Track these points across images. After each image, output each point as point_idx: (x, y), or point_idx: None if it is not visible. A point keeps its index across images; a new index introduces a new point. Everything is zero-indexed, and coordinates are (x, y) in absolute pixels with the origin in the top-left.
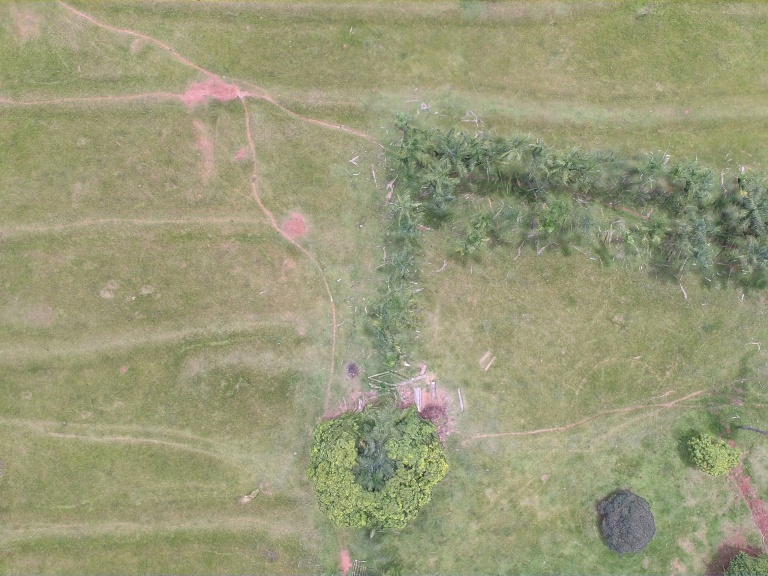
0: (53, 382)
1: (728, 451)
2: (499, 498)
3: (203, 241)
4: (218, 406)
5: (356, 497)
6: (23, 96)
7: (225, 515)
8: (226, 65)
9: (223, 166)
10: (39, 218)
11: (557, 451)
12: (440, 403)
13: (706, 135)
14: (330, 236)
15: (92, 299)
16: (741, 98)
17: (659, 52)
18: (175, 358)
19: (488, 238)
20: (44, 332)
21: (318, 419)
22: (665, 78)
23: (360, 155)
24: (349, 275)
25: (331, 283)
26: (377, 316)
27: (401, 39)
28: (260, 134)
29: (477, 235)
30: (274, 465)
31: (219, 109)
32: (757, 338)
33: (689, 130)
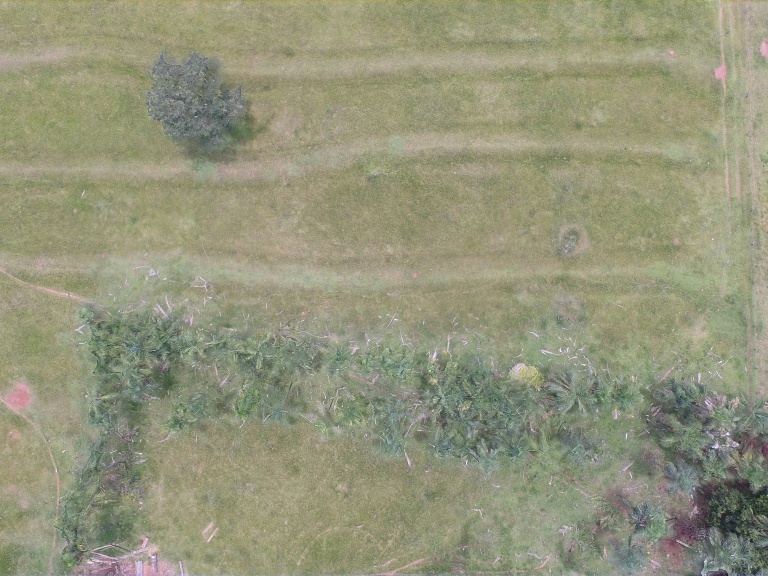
0: None
1: None
2: None
3: None
4: None
5: None
6: None
7: None
8: None
9: None
10: None
11: None
12: None
13: (435, 298)
14: (54, 407)
15: None
16: (471, 260)
17: (390, 214)
18: None
19: (195, 418)
20: None
21: None
22: (396, 240)
23: None
24: (73, 446)
25: (56, 454)
26: None
27: (133, 203)
28: None
29: (177, 420)
30: None
31: None
32: (480, 504)
33: (418, 293)
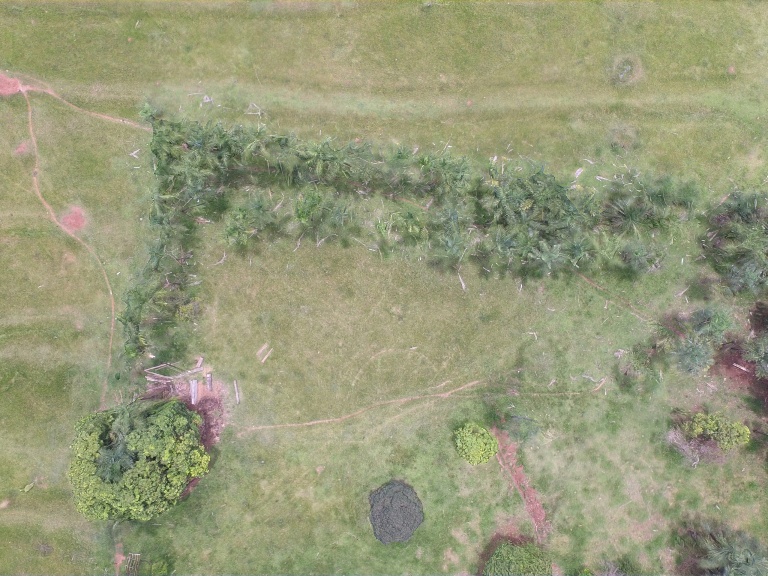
0: None
1: (485, 440)
2: (274, 490)
3: None
4: None
5: (94, 489)
6: None
7: None
8: (9, 59)
9: (4, 160)
10: None
11: (332, 442)
12: (216, 395)
13: (488, 126)
14: (109, 229)
15: None
16: (525, 89)
17: (444, 43)
18: None
19: (253, 230)
20: None
21: (94, 412)
22: (449, 69)
23: (141, 148)
24: (128, 268)
25: (110, 276)
26: None
27: (186, 32)
28: (41, 128)
29: (236, 227)
30: (50, 459)
31: (1, 103)
32: (534, 328)
33: (472, 121)
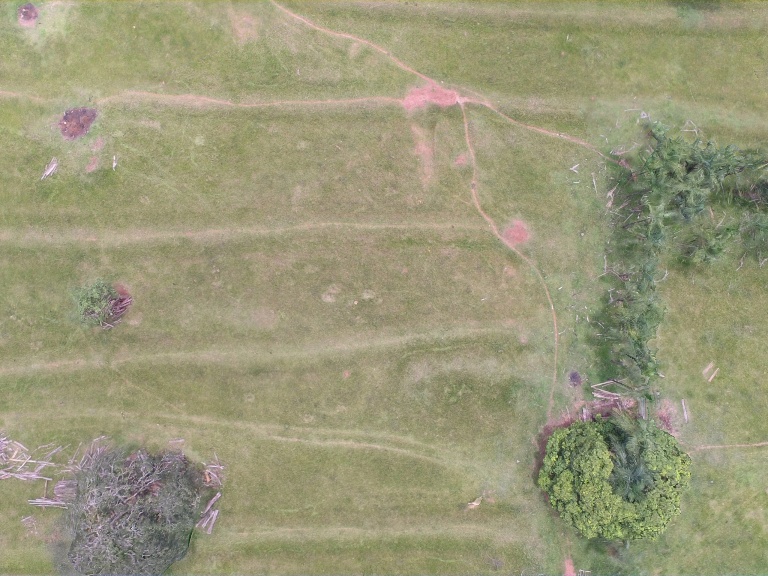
0: (276, 385)
1: None
2: (724, 510)
3: (423, 247)
4: (441, 412)
5: (617, 508)
6: (243, 98)
7: (449, 522)
8: (444, 70)
9: (443, 172)
10: (259, 221)
11: None
12: (664, 414)
13: None
14: (552, 244)
15: (313, 303)
16: None
17: None
18: (398, 363)
19: None
20: (266, 335)
21: (541, 427)
22: None
23: (581, 163)
24: (571, 283)
25: (552, 291)
26: (599, 325)
27: (618, 47)
28: (480, 140)
29: (720, 246)
30: (497, 473)
31: (438, 114)
32: None
33: None
